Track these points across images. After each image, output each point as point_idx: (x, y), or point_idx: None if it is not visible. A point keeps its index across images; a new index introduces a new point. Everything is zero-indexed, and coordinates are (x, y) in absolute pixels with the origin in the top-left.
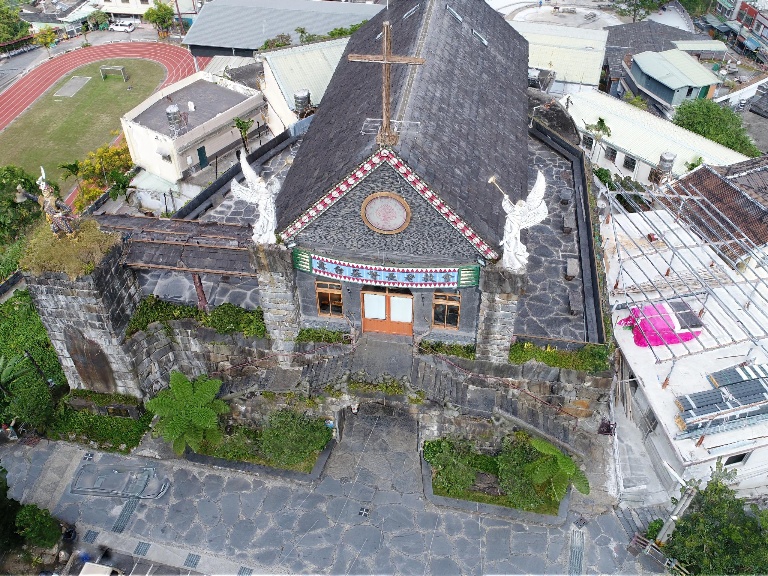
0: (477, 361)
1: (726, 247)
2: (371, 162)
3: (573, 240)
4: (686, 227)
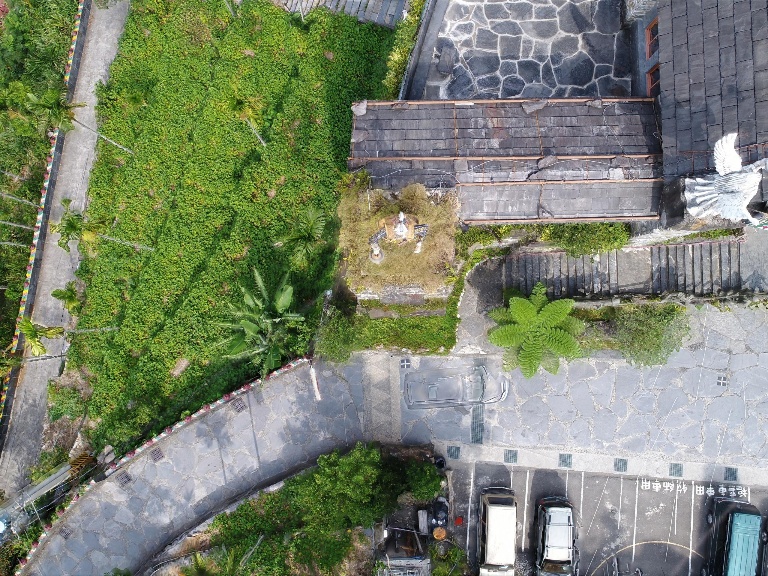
0: None
1: None
2: None
3: None
4: None
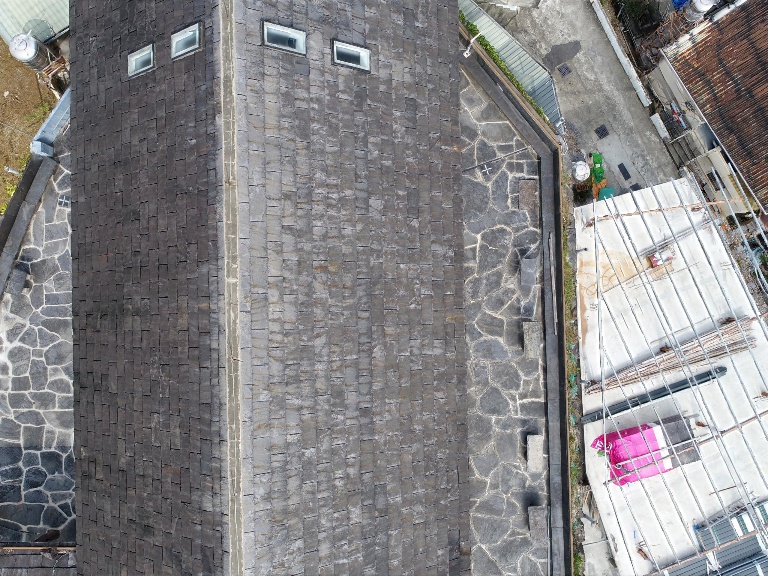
0: None
1: (760, 181)
2: None
3: (537, 367)
4: (708, 225)
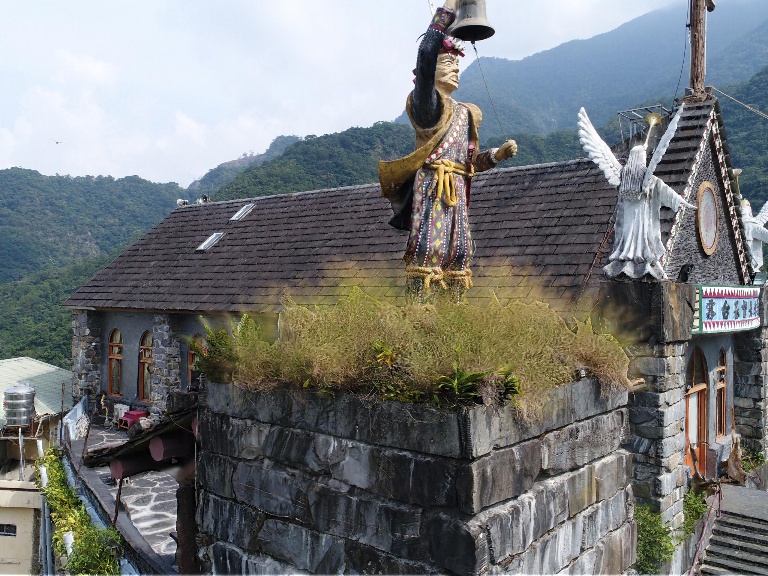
0: (763, 465)
1: None
2: (705, 127)
3: None
4: None
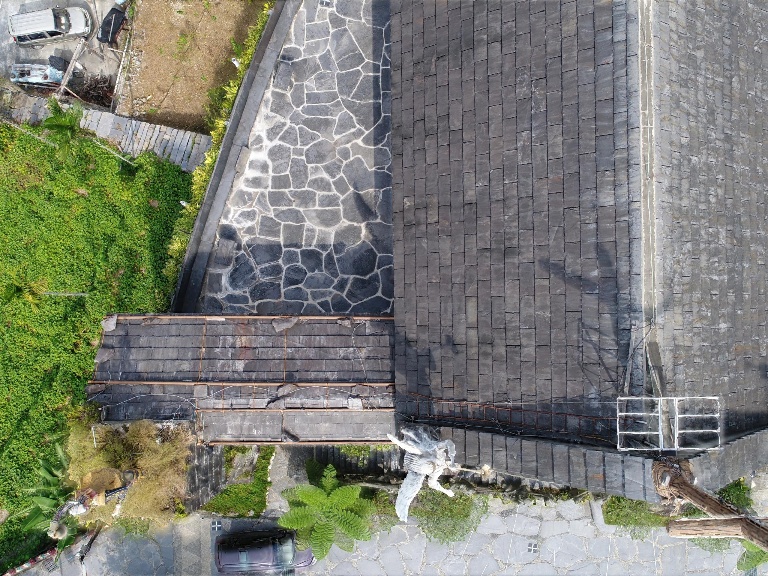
0: None
1: None
2: None
3: None
4: None
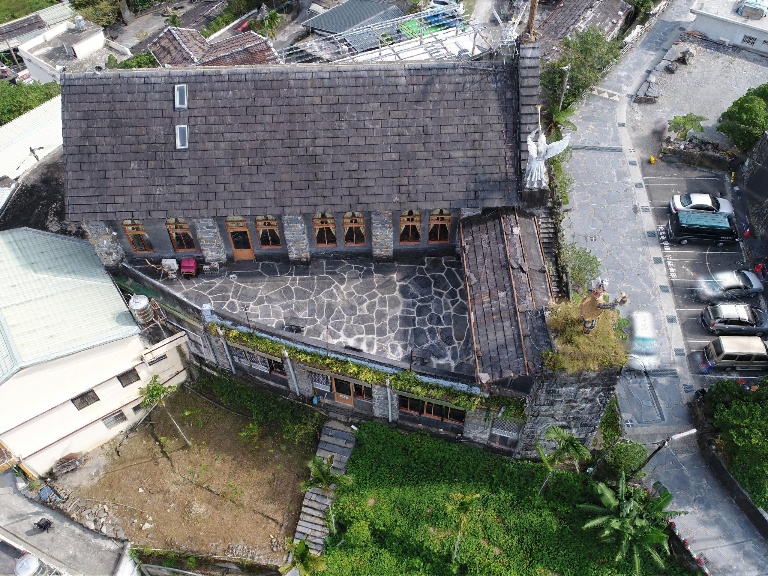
0: None
1: None
2: None
3: None
4: None
